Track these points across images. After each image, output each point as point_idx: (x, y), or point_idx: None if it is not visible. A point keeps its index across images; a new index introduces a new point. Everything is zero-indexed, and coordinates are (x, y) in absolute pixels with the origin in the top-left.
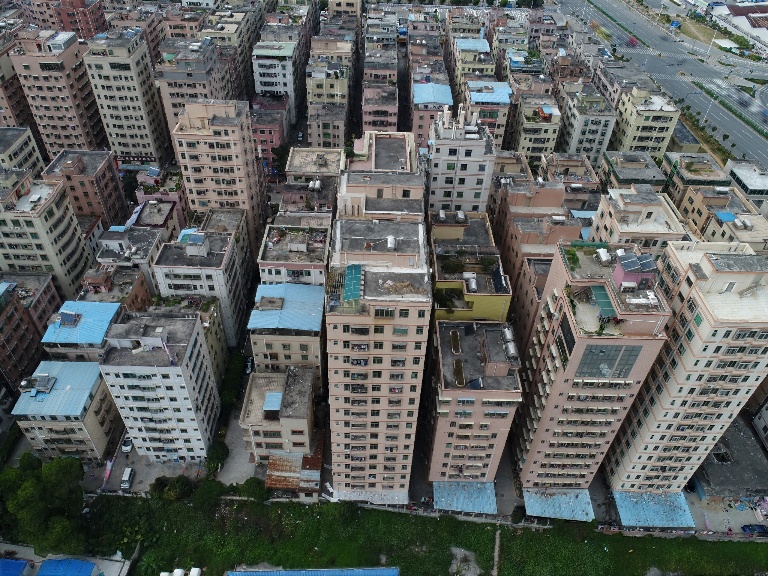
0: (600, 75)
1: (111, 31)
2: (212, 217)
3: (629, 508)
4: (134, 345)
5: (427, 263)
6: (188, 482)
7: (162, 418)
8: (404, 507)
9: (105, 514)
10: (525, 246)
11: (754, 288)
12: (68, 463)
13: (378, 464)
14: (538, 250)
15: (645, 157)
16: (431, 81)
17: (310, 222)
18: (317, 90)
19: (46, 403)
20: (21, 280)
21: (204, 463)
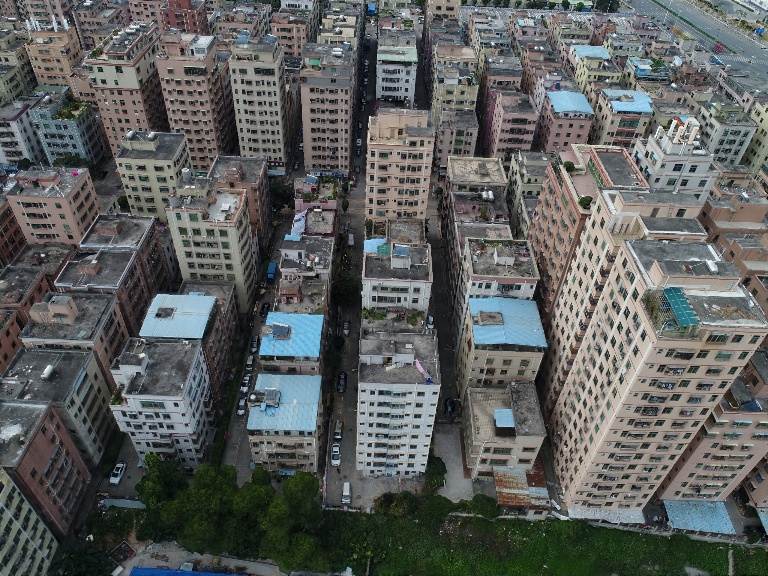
0: (722, 84)
1: (220, 33)
2: (391, 227)
3: None
4: (384, 361)
5: (742, 287)
6: (413, 498)
7: (398, 434)
8: (637, 526)
9: (332, 530)
10: (744, 263)
11: None
12: (310, 479)
13: (627, 484)
14: (758, 267)
15: None
16: (560, 88)
17: (489, 233)
18: (447, 96)
19: (278, 418)
20: (205, 289)
21: (417, 478)
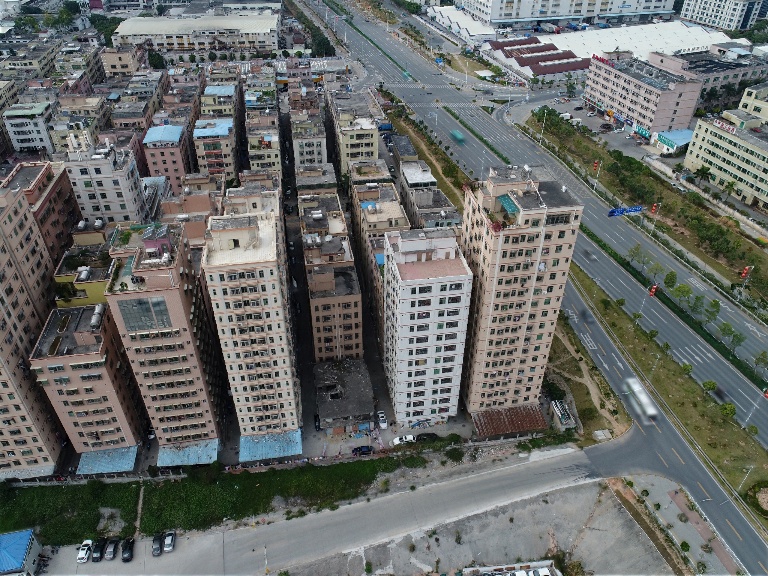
0: (331, 106)
1: None
2: None
3: (249, 448)
4: None
5: None
6: None
7: None
8: (53, 479)
9: None
10: None
11: (250, 241)
12: None
13: (8, 440)
14: None
15: (327, 167)
16: (170, 124)
17: None
18: (63, 141)
19: None
20: None
21: None
